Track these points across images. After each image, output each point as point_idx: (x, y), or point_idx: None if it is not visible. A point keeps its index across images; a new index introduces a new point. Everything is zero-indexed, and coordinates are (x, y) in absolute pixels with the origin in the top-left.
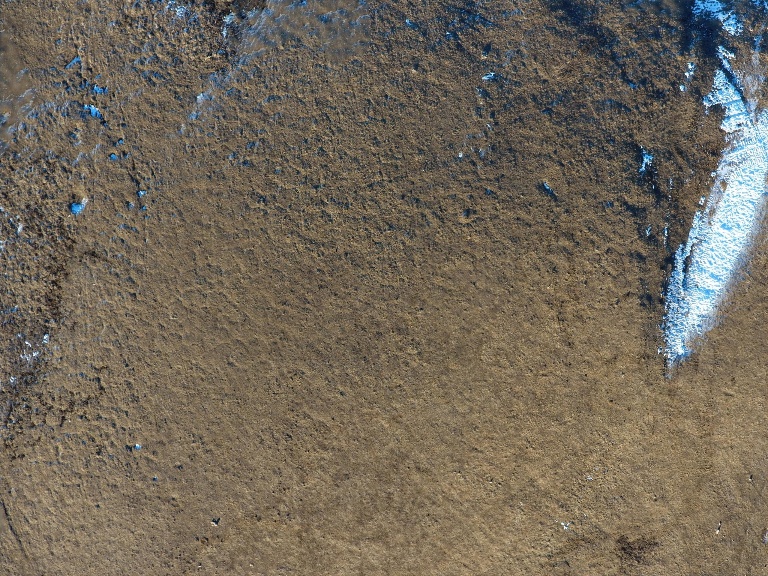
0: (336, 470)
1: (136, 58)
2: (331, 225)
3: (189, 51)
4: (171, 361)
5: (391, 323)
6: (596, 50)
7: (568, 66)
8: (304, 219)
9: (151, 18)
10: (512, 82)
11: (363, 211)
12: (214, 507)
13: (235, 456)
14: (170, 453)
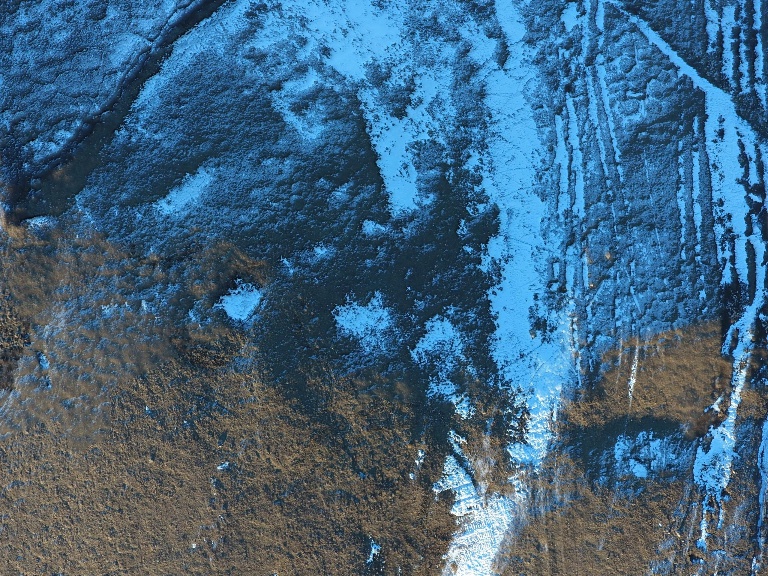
0: None
1: None
2: None
3: None
4: None
5: None
6: (328, 439)
7: (301, 455)
8: None
9: None
10: (245, 472)
11: None
12: None
13: None
14: None
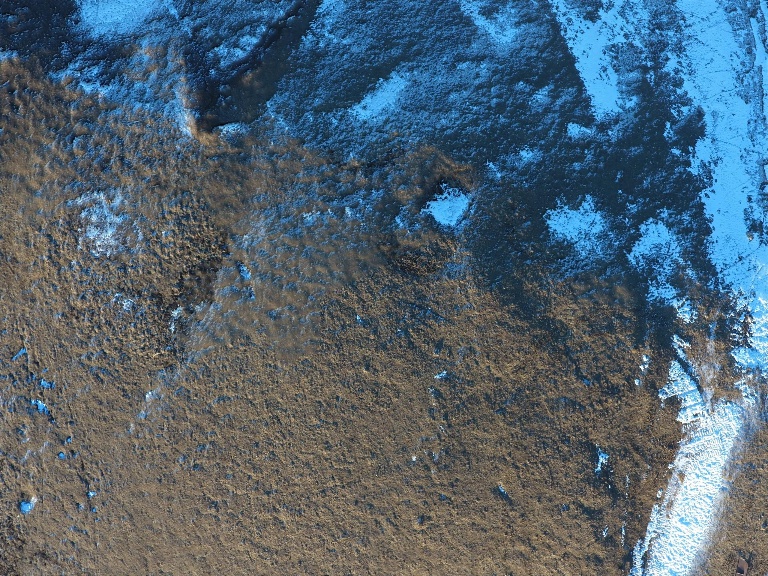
0: None
1: (83, 353)
2: (284, 533)
3: (137, 347)
4: None
5: None
6: (549, 345)
7: (521, 363)
8: (256, 526)
9: (98, 311)
10: (465, 381)
11: (316, 518)
12: None
13: None
14: None
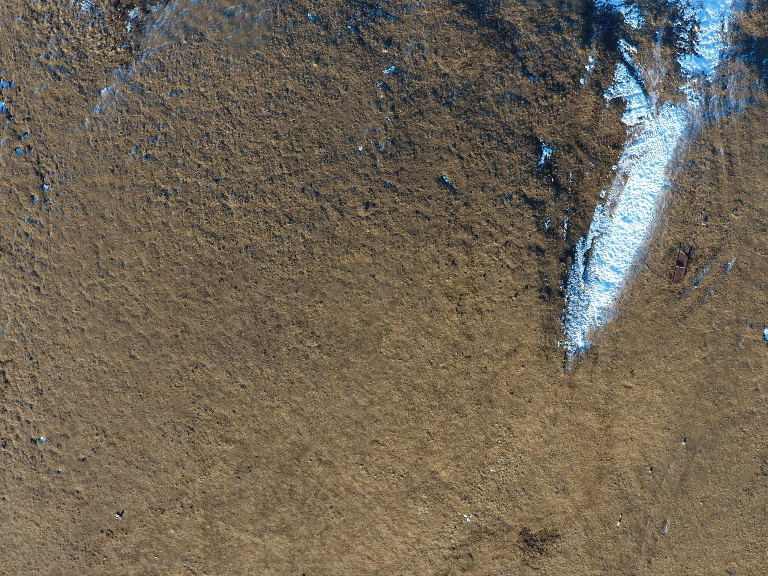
0: (238, 463)
1: (42, 52)
2: (231, 218)
3: (94, 45)
4: (74, 354)
5: (291, 316)
6: (497, 43)
7: (468, 59)
8: (205, 212)
9: (57, 13)
10: (412, 75)
11: (263, 204)
12: (118, 500)
13: (138, 449)
14: (74, 446)
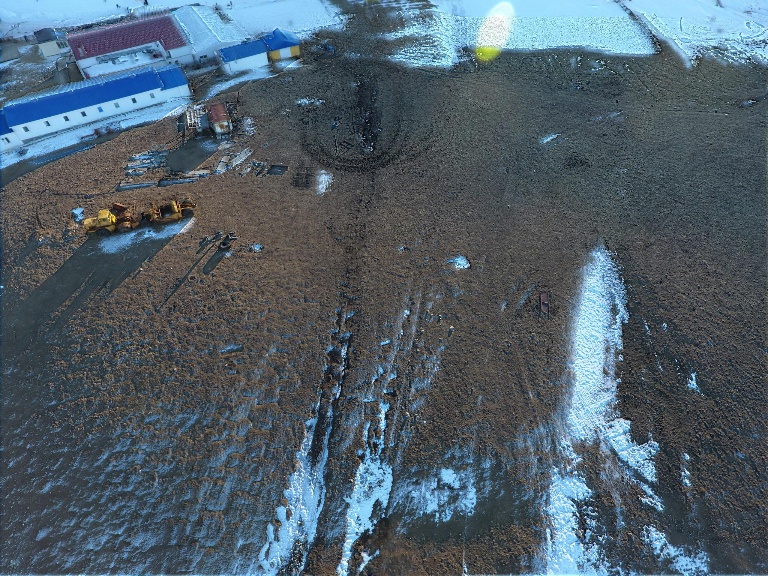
0: None
1: None
2: None
3: None
4: None
5: None
6: None
7: None
8: None
9: None
10: None
11: None
12: None
13: None
14: None
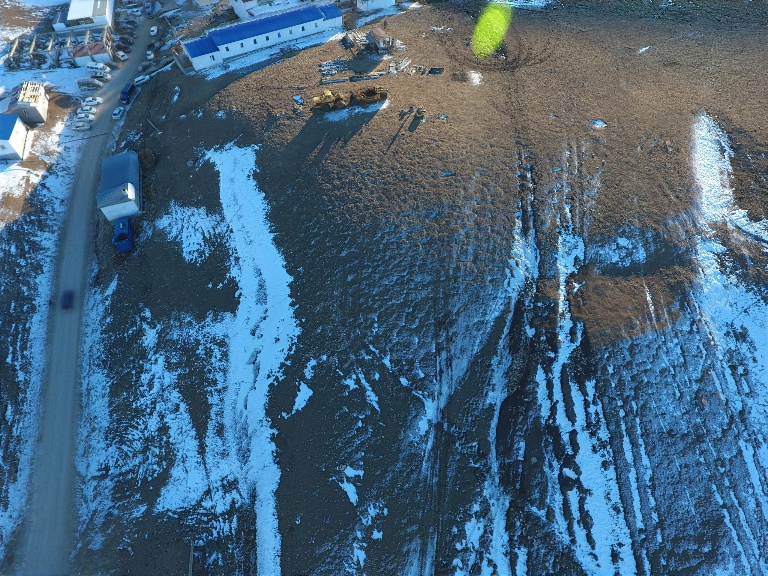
0: None
1: None
2: None
3: None
4: None
5: None
6: None
7: None
8: None
9: None
10: None
11: None
12: None
13: None
14: None
